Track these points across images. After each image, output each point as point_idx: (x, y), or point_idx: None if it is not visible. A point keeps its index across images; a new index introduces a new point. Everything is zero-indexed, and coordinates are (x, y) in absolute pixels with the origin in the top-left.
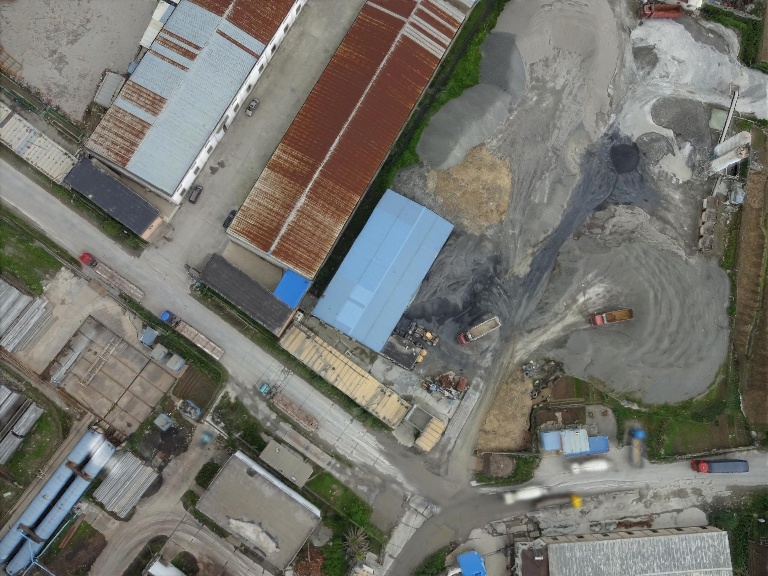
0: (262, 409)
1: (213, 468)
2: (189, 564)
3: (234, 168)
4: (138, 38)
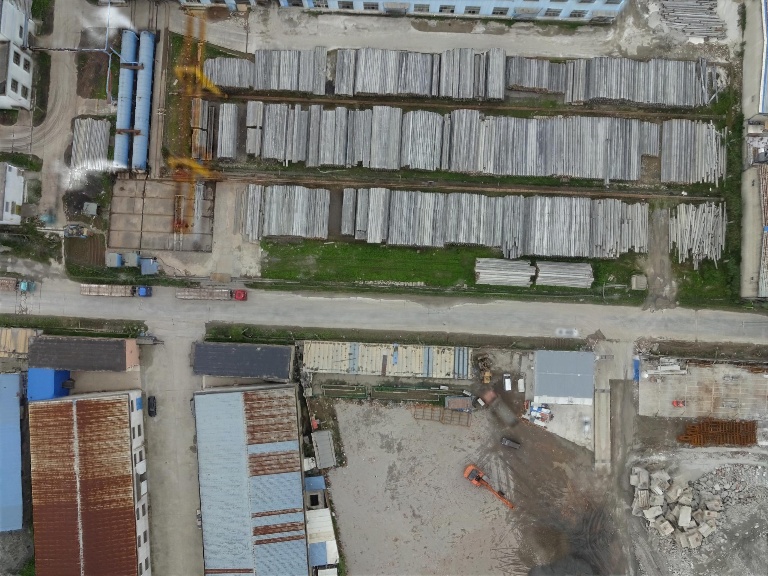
0: (22, 268)
1: (31, 199)
2: (3, 118)
3: (181, 453)
4: (340, 512)
